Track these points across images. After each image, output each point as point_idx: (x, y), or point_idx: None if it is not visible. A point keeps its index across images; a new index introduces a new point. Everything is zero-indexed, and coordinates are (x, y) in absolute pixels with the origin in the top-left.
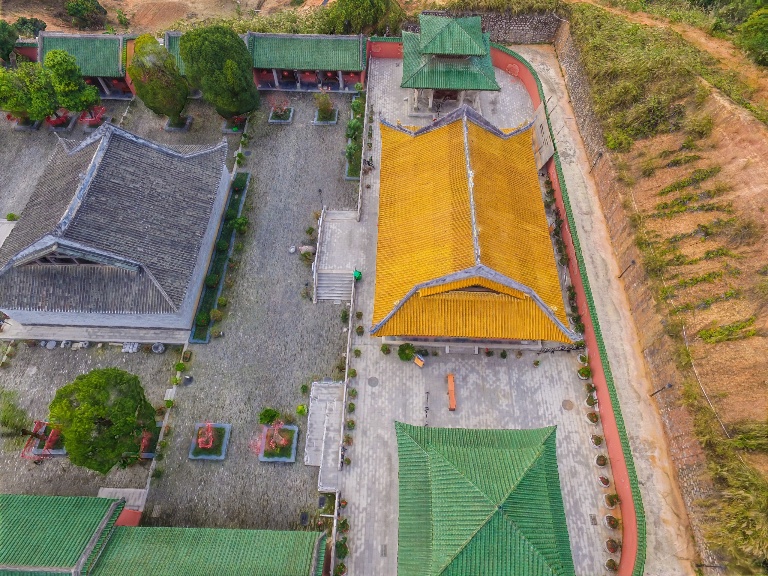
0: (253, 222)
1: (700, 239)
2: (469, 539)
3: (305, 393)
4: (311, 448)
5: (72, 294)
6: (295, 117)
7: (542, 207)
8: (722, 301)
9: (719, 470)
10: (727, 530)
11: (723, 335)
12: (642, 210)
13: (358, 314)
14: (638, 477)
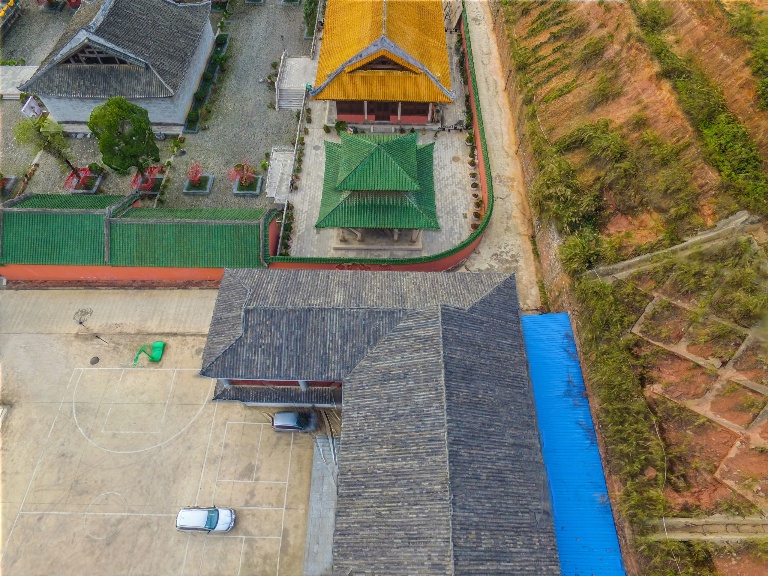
0: (232, 65)
1: (551, 42)
2: (359, 163)
3: (268, 158)
4: (271, 187)
5: (97, 85)
6: (266, 0)
7: (443, 32)
8: (559, 74)
9: (541, 162)
10: (538, 187)
11: (556, 93)
12: (519, 37)
13: (308, 109)
14: (500, 195)
